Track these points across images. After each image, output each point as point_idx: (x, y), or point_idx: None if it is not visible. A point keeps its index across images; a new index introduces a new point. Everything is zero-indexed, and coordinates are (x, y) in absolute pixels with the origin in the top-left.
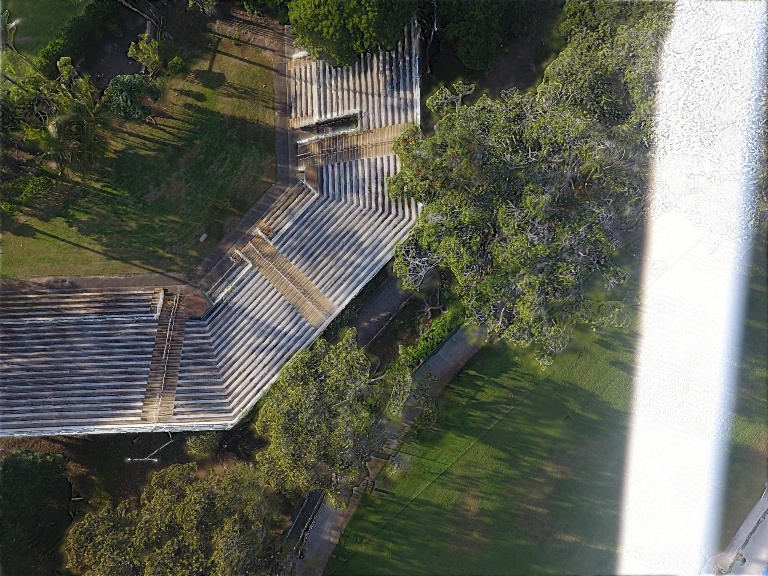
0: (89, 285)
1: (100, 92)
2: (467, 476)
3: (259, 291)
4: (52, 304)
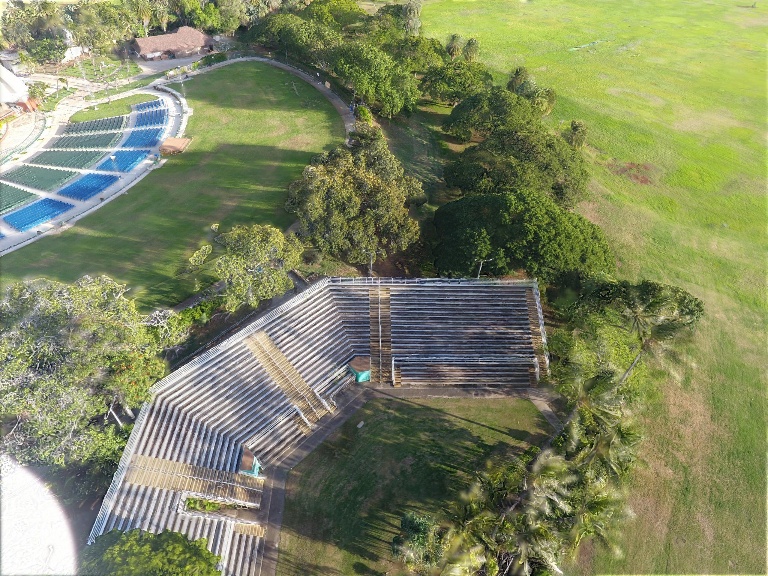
0: (455, 391)
1: (471, 574)
2: (187, 263)
3: (309, 369)
4: (480, 376)
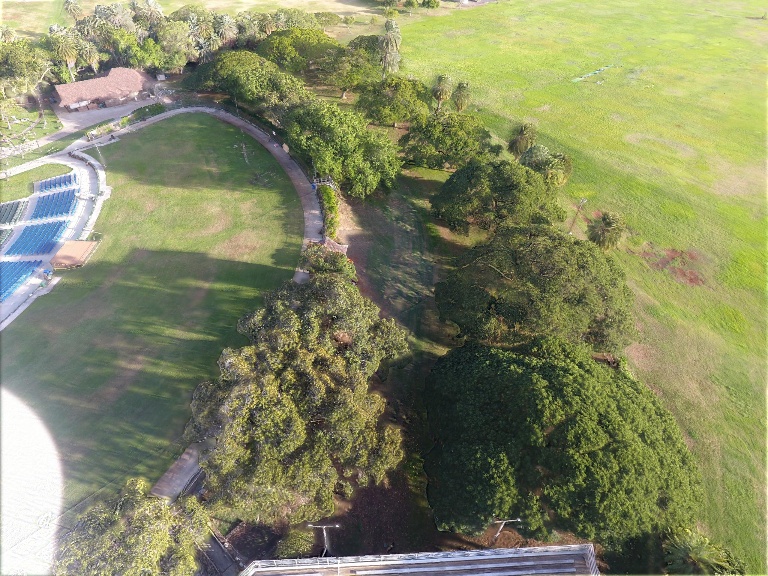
0: None
1: None
2: (39, 512)
3: None
4: None
